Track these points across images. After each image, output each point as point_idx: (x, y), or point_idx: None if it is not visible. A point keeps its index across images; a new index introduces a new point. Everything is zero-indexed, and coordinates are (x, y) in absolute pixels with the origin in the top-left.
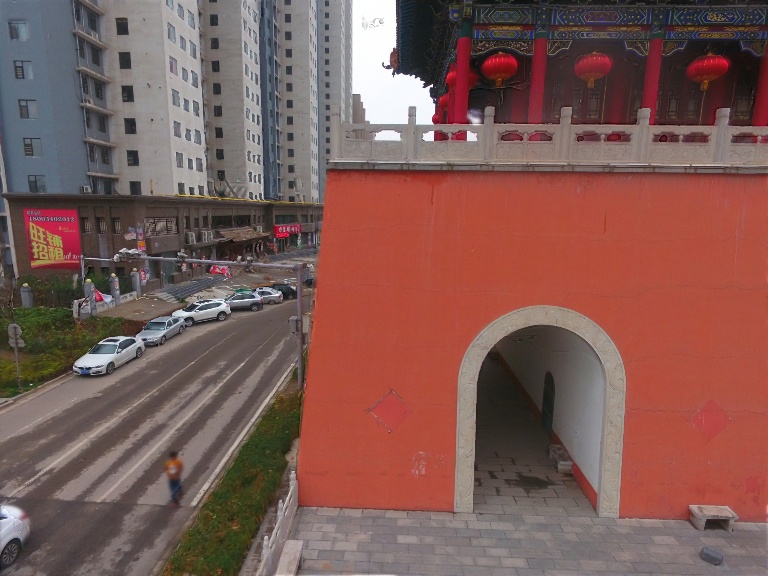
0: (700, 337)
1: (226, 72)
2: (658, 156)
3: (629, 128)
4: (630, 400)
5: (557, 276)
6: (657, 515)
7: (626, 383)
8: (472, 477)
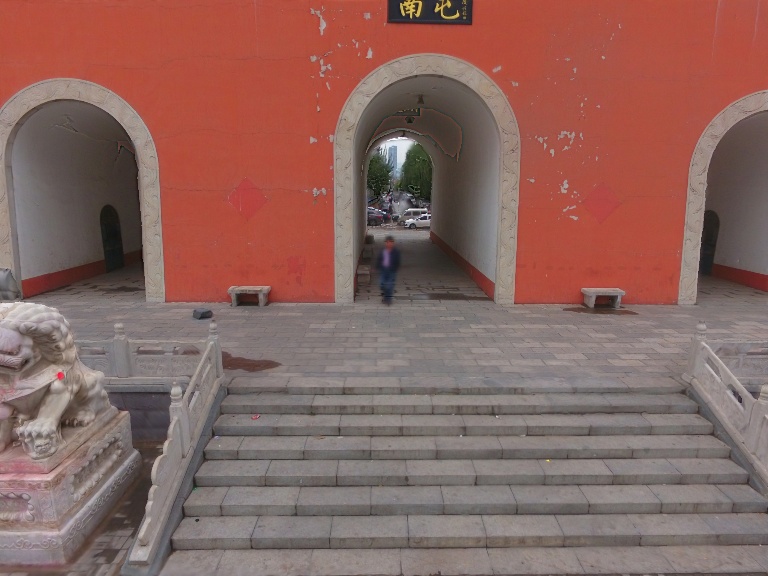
0: (229, 112)
1: None
2: None
3: None
4: (165, 179)
5: (76, 46)
6: (204, 298)
7: (158, 161)
8: (12, 264)
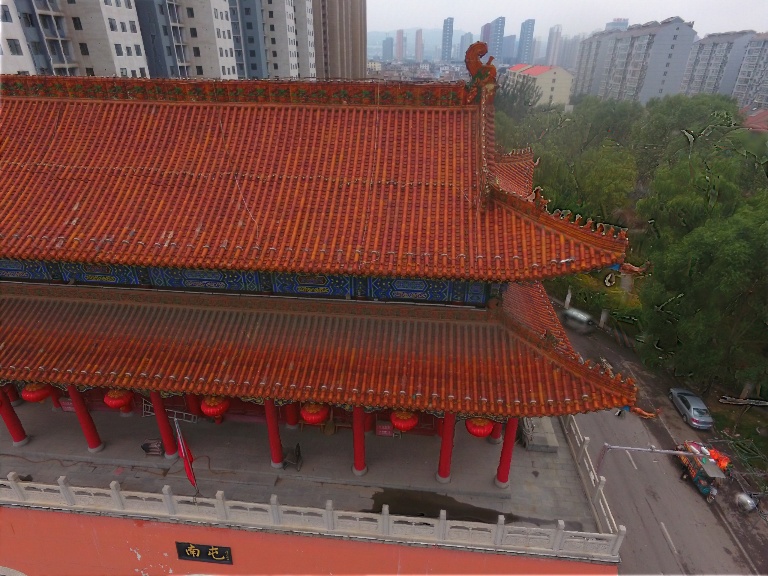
0: None
1: (90, 30)
2: (33, 497)
3: (6, 483)
4: None
5: None
6: None
7: None
8: None
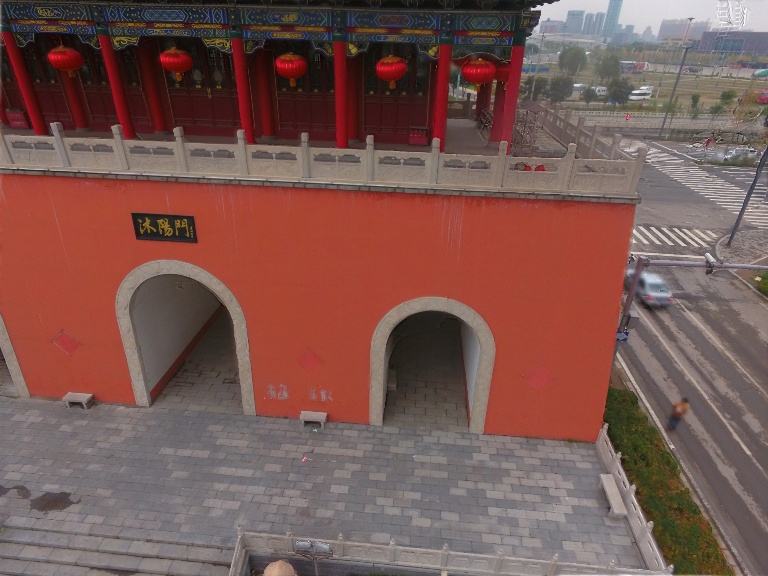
0: None
1: None
2: None
3: None
4: None
5: None
6: None
7: None
8: None
